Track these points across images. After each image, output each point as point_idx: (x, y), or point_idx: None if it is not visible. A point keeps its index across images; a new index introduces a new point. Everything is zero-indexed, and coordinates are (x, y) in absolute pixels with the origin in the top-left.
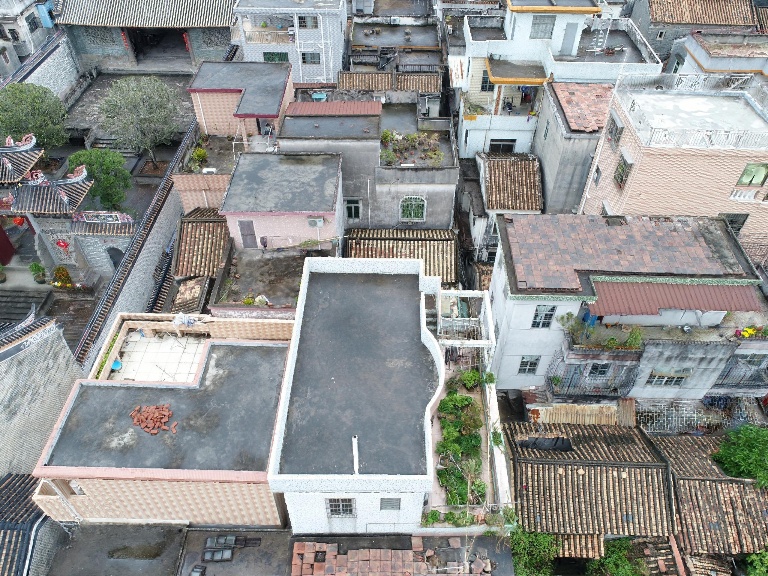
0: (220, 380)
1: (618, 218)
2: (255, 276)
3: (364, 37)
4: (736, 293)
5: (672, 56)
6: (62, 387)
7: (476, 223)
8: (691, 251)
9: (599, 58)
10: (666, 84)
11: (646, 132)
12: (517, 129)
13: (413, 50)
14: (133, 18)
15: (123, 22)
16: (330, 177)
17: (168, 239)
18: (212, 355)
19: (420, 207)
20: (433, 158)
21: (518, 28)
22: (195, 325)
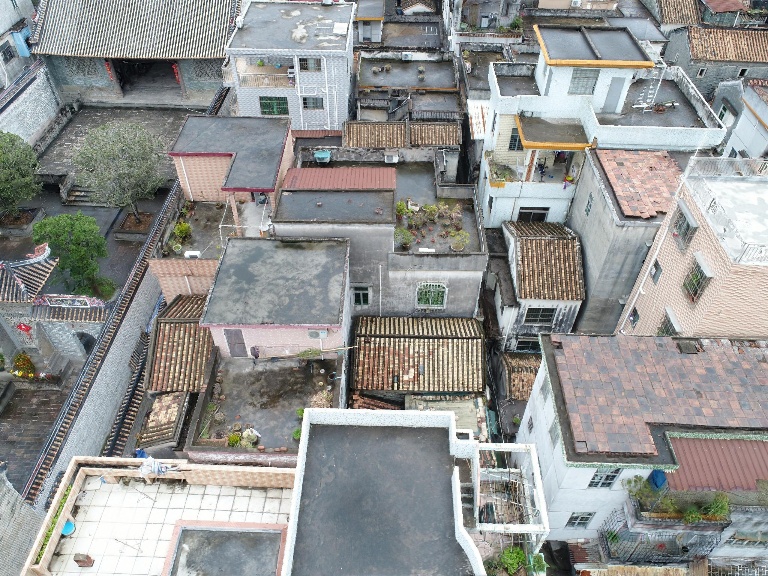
0: None
1: (691, 340)
2: (244, 397)
3: (372, 75)
4: None
5: (717, 99)
6: (5, 540)
7: (505, 312)
8: None
9: (648, 117)
10: (747, 170)
11: (730, 240)
12: (551, 197)
13: (427, 91)
14: (118, 48)
15: (106, 52)
16: (335, 273)
17: (148, 316)
18: (183, 546)
19: (440, 295)
20: (455, 236)
21: (555, 83)
22: (167, 473)
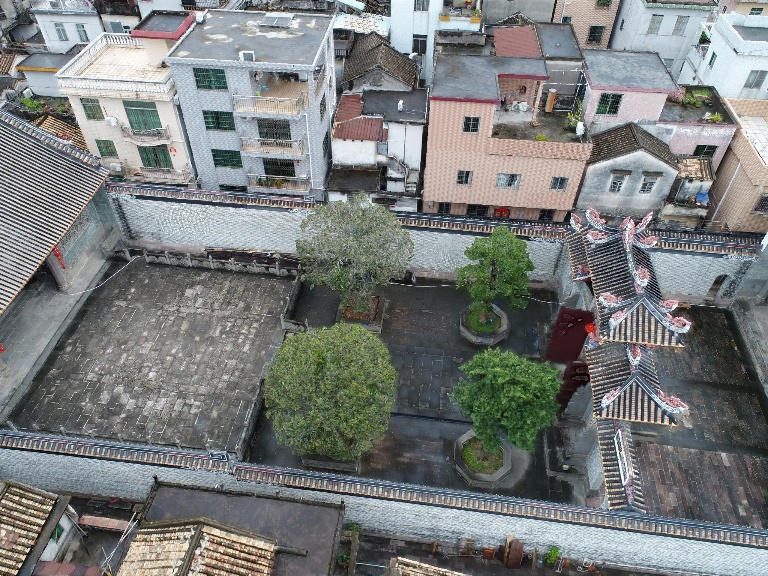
0: None
1: None
2: None
3: None
4: None
5: None
6: None
7: None
8: None
9: None
10: None
11: None
12: None
13: None
14: None
15: None
16: (613, 53)
17: None
18: None
19: None
20: None
21: None
22: None
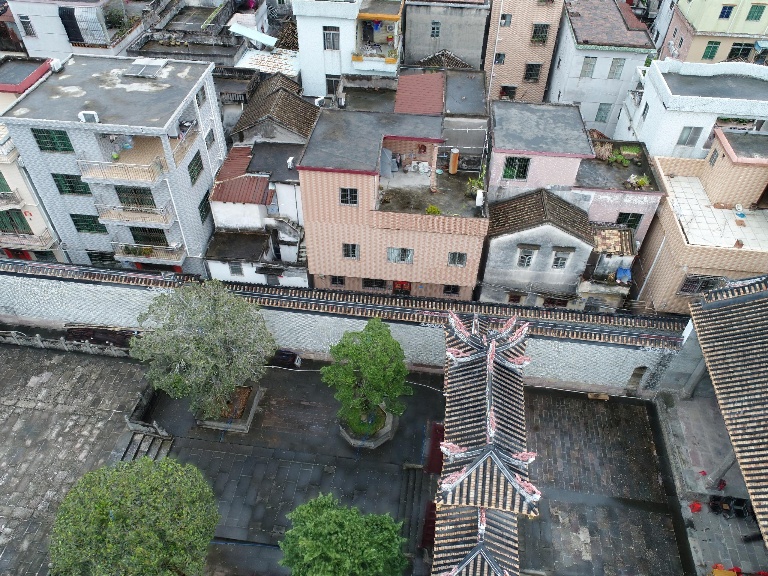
0: (764, 155)
1: (569, 15)
2: None
3: None
4: (620, 5)
5: None
6: None
7: None
8: (597, 3)
9: None
10: None
11: None
12: None
13: None
14: None
15: None
16: (528, 106)
17: None
18: None
19: None
20: None
21: None
22: None
